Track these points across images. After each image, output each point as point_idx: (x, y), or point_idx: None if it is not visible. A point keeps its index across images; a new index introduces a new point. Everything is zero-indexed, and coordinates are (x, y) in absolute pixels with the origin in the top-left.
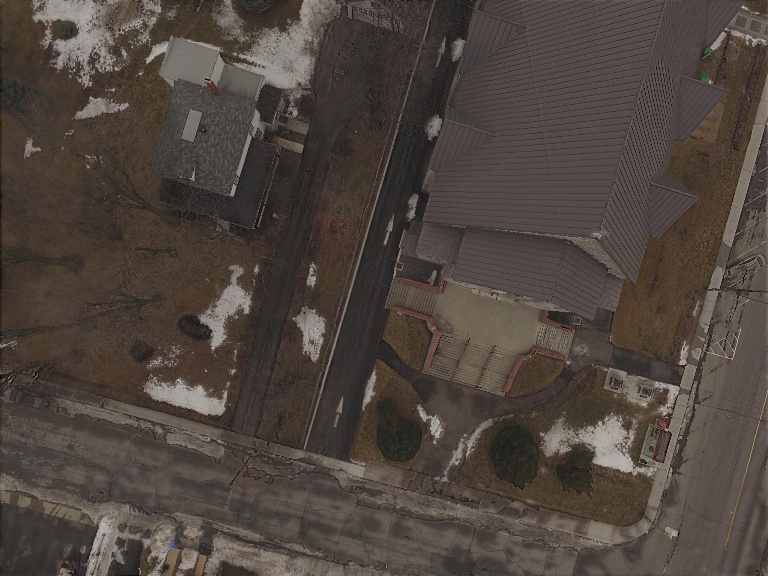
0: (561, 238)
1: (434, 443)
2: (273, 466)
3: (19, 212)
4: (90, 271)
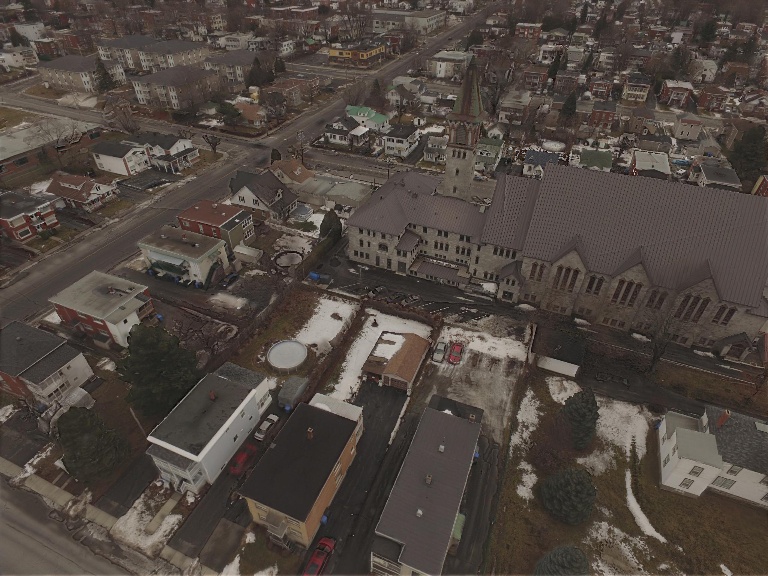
0: None
1: None
2: None
3: None
4: None
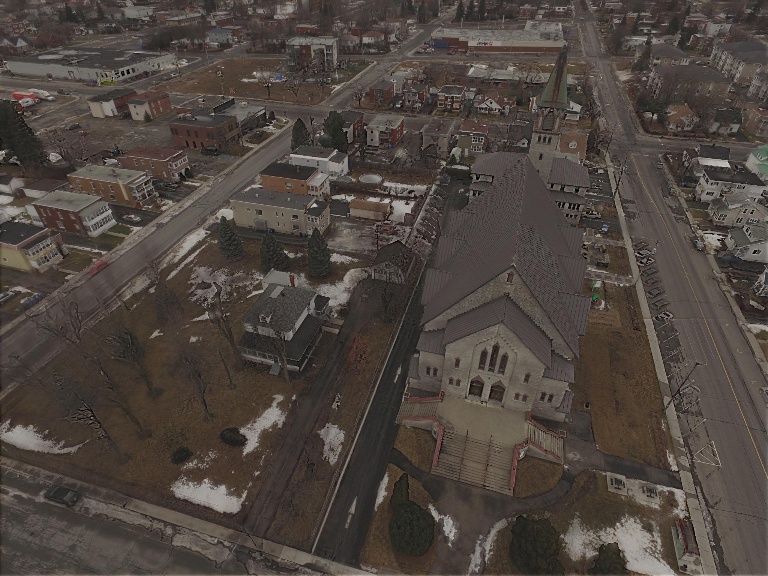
0: (502, 295)
1: (449, 546)
2: (276, 572)
3: (131, 363)
4: (164, 399)
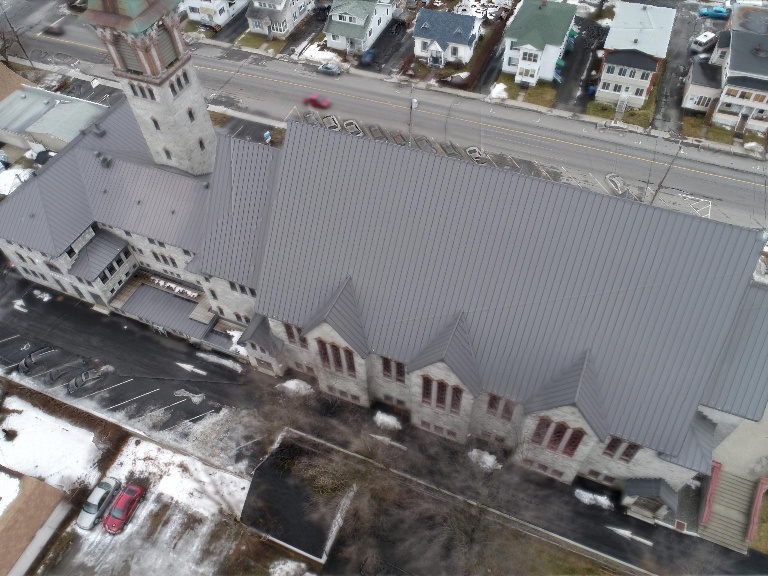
0: None
1: None
2: None
3: None
4: None
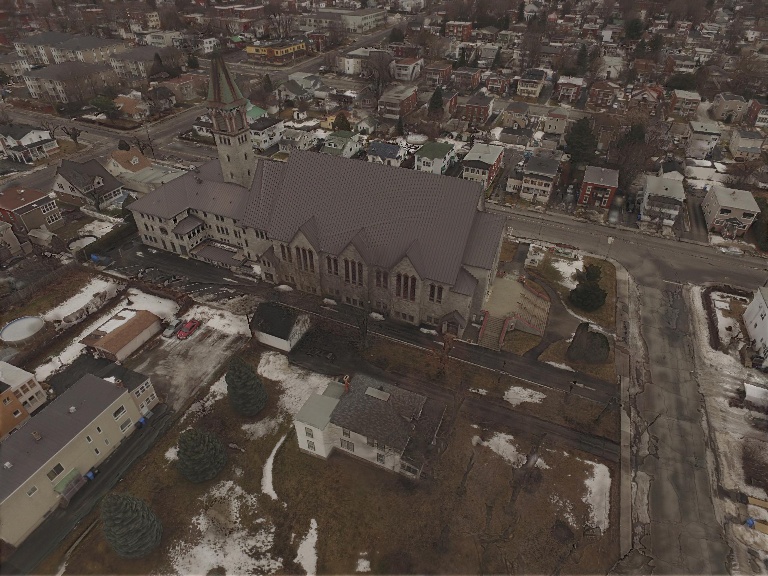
0: None
1: None
2: None
3: None
4: None
